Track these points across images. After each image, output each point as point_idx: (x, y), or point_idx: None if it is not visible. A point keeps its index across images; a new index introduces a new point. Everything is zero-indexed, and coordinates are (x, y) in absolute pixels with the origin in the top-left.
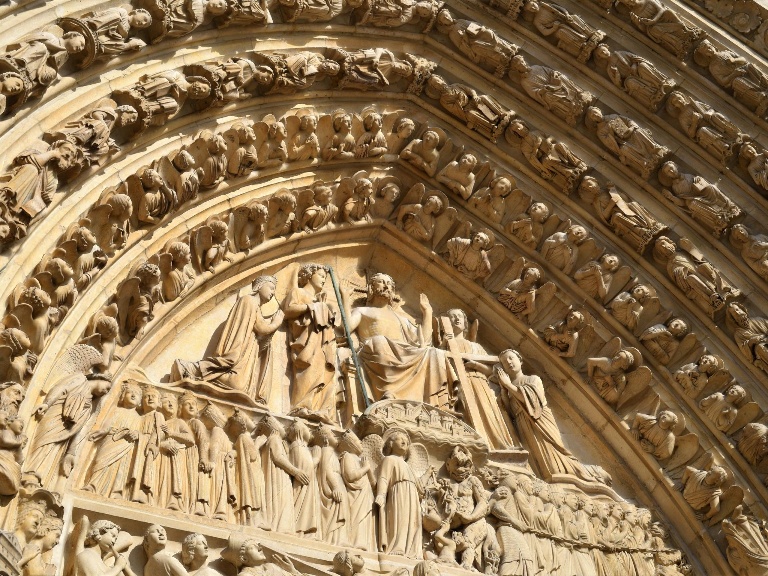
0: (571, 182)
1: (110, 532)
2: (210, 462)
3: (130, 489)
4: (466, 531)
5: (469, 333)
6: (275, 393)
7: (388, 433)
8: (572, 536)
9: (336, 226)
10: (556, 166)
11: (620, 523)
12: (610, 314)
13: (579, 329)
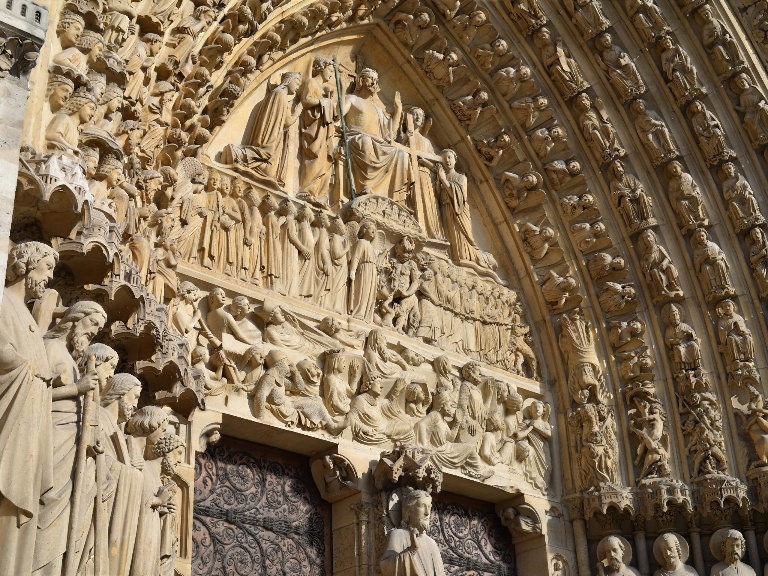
0: (531, 30)
1: (193, 292)
2: (251, 238)
3: (201, 255)
4: (402, 303)
5: (423, 127)
6: (289, 174)
7: (363, 221)
8: (465, 310)
9: (347, 25)
10: (524, 14)
11: (496, 302)
12: (529, 141)
13: (504, 148)
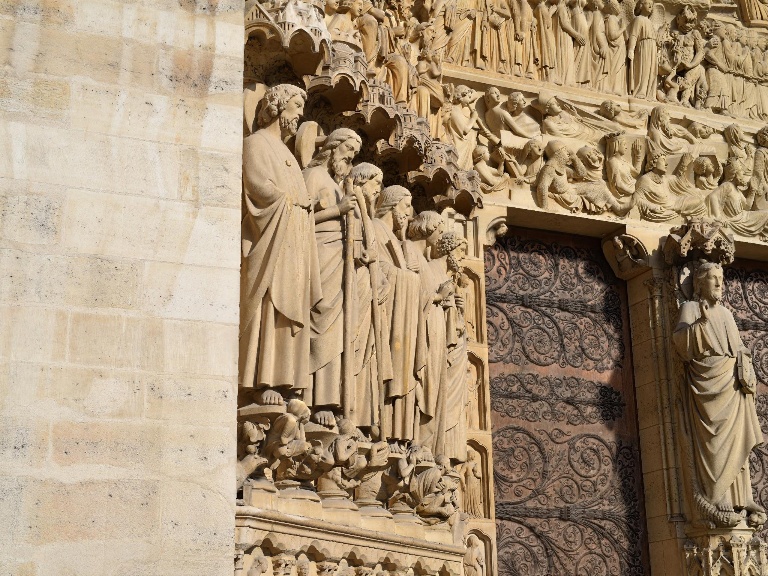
0: None
1: (468, 95)
2: (522, 32)
3: (473, 57)
4: (687, 75)
5: None
6: None
7: None
8: (758, 74)
9: None
10: None
11: None
12: None
13: None
